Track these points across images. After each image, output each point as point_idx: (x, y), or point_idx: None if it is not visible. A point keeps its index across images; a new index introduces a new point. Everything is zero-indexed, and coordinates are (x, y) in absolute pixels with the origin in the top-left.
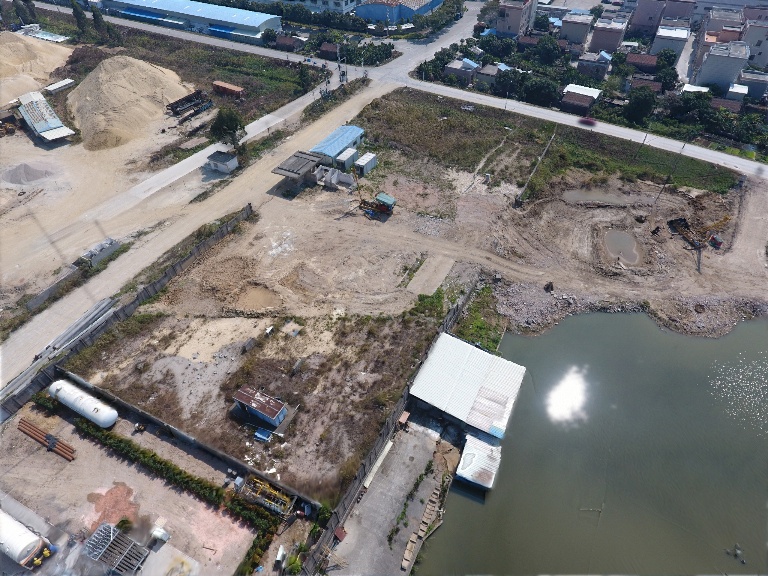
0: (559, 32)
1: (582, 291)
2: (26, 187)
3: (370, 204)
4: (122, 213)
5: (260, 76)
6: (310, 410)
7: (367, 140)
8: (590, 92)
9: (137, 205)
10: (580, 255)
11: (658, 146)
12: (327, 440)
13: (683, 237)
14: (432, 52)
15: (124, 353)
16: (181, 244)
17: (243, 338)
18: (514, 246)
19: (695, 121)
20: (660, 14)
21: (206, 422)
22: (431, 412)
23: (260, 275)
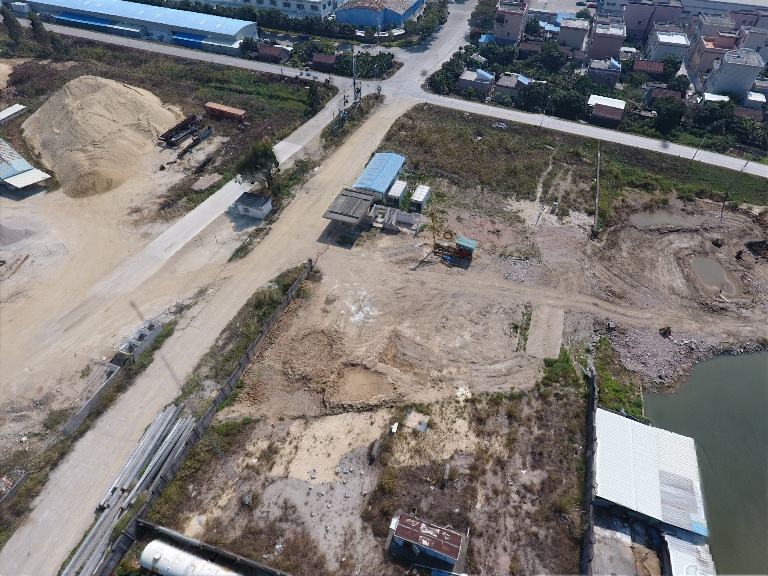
0: (553, 37)
1: (698, 332)
2: (4, 254)
3: (446, 248)
4: (146, 281)
5: (256, 94)
6: (483, 533)
7: (406, 168)
8: (615, 103)
9: (162, 268)
10: (677, 289)
11: (707, 161)
12: (520, 573)
13: (767, 261)
14: (433, 61)
15: (218, 483)
16: (238, 318)
17: (363, 441)
18: (609, 285)
19: (722, 131)
20: (649, 18)
21: (362, 571)
22: (614, 510)
23: (353, 352)
